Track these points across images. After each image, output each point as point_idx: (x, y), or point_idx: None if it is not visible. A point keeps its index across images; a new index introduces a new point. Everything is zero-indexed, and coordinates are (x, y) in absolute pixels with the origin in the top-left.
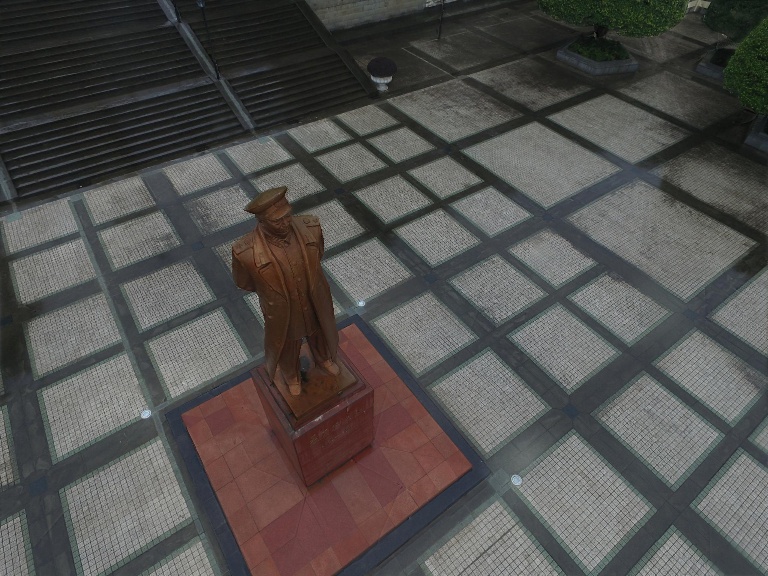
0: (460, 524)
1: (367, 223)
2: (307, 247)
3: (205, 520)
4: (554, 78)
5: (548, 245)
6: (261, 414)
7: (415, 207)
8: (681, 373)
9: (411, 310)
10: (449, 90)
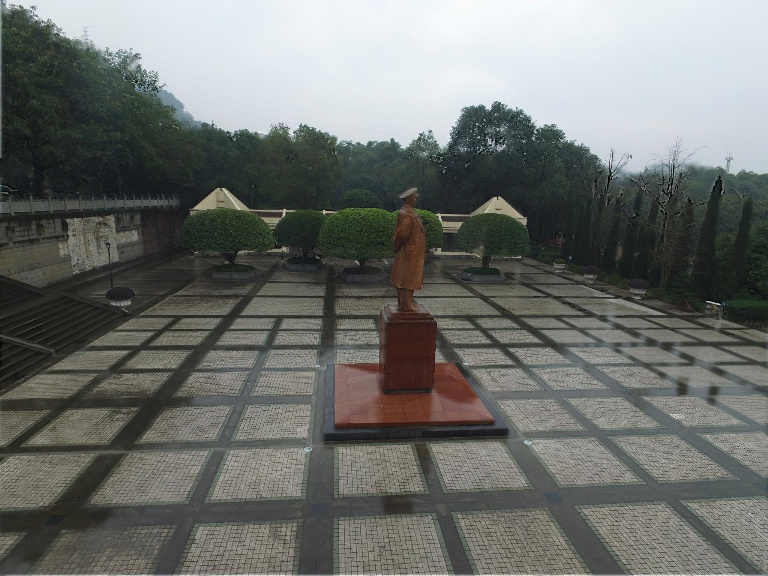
0: (477, 379)
1: (253, 348)
2: None
3: (417, 440)
4: (228, 284)
5: (347, 322)
6: (370, 395)
7: (265, 335)
8: (447, 326)
9: (342, 356)
10: (176, 301)
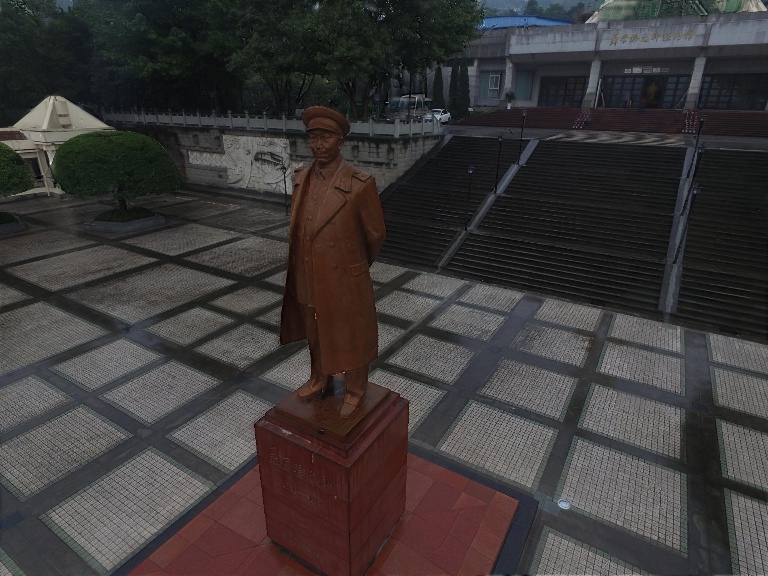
0: None
1: (694, 455)
2: (335, 190)
3: None
4: None
5: None
6: None
7: None
8: None
9: None
10: None
